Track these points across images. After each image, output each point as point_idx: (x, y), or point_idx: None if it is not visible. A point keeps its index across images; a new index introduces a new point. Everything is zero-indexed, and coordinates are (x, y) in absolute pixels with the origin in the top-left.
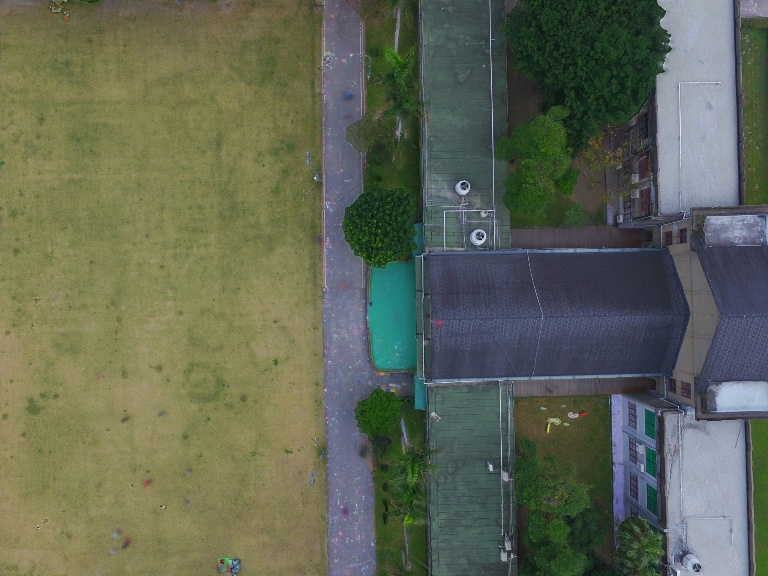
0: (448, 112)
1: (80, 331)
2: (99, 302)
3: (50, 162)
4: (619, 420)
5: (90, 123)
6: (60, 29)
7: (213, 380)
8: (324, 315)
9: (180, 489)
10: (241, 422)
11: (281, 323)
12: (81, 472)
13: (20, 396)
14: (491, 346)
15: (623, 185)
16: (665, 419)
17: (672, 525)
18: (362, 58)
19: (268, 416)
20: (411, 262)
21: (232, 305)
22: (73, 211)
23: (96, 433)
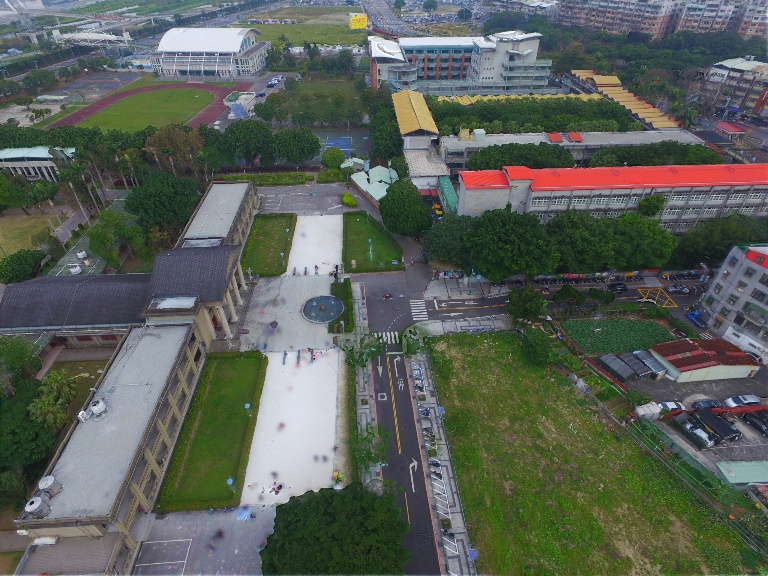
0: None
1: None
2: None
3: None
4: None
5: None
6: None
7: None
8: None
9: None
10: None
11: None
12: None
13: None
14: (40, 304)
15: None
16: (129, 327)
17: (103, 390)
18: None
19: None
20: None
21: None
22: None
23: None
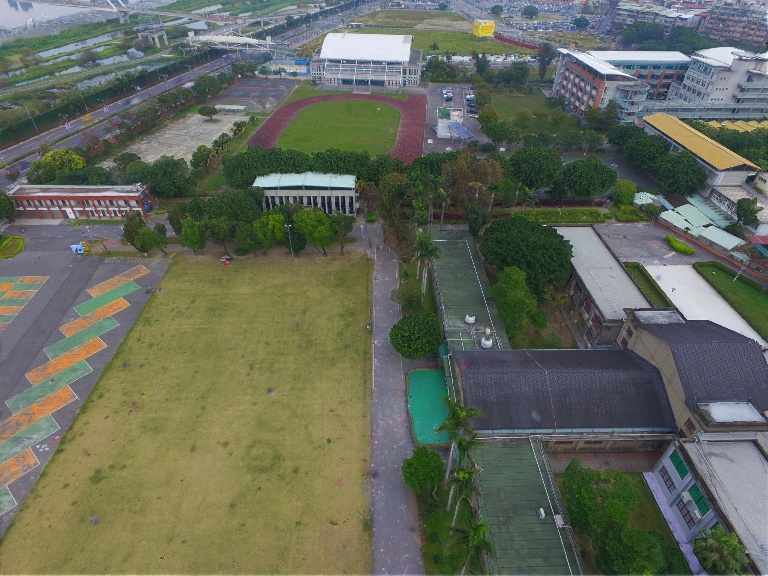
0: (454, 289)
1: (168, 416)
2: (192, 396)
3: (190, 320)
4: (661, 496)
5: (224, 303)
6: (221, 267)
7: (271, 454)
8: (372, 407)
9: (212, 562)
10: (290, 492)
11: (336, 412)
12: (114, 542)
13: (90, 467)
14: (513, 397)
15: (582, 329)
16: (683, 444)
17: (753, 552)
18: (397, 278)
19: (317, 487)
20: (440, 370)
21: (298, 399)
22: (194, 343)
23: (146, 501)
